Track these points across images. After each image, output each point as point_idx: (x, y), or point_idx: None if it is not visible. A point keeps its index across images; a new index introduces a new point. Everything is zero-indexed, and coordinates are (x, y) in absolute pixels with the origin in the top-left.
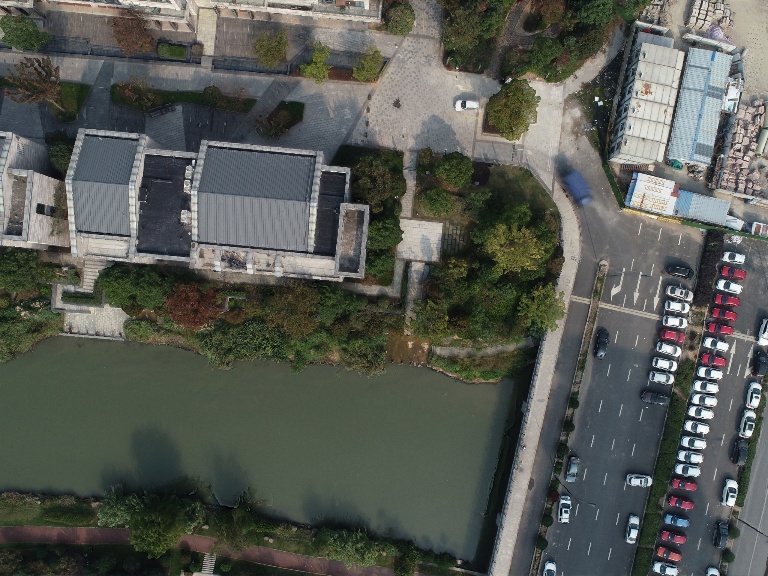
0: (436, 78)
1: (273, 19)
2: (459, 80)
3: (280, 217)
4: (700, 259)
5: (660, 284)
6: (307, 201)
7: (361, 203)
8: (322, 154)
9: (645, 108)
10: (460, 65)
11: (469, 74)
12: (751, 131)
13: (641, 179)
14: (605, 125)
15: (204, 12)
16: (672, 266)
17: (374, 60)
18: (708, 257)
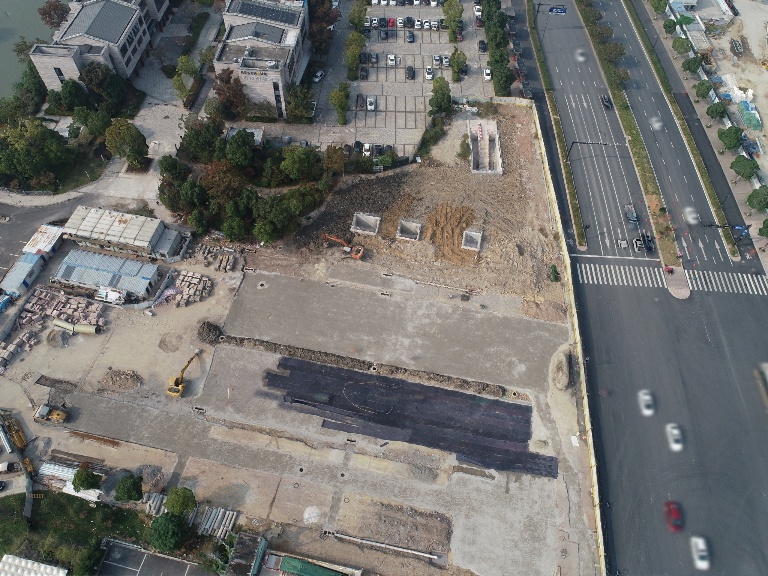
0: None
1: None
2: None
3: None
4: None
5: None
6: None
7: None
8: (116, 46)
9: (108, 220)
10: None
11: None
12: None
13: (59, 230)
14: None
15: None
16: None
17: (182, 86)
18: None
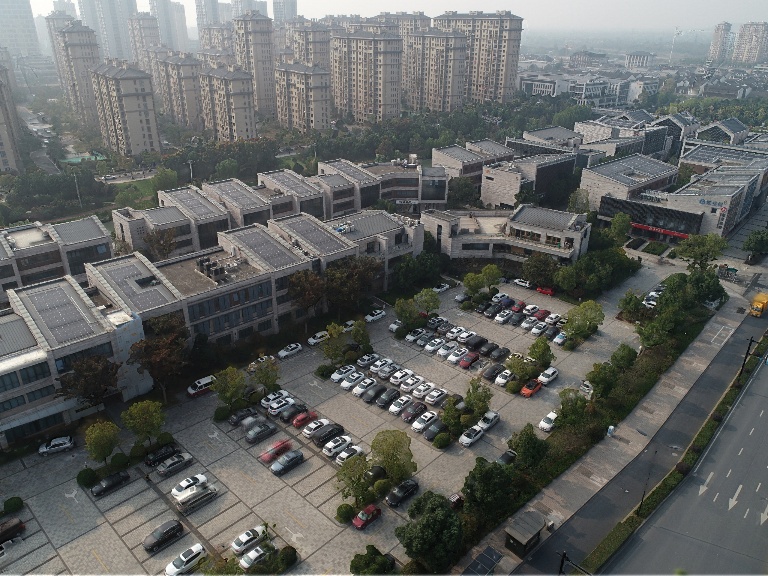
0: None
1: None
2: None
3: None
4: None
5: None
6: None
7: None
8: None
9: None
10: None
11: None
12: None
13: None
14: None
15: None
16: None
17: None
18: None
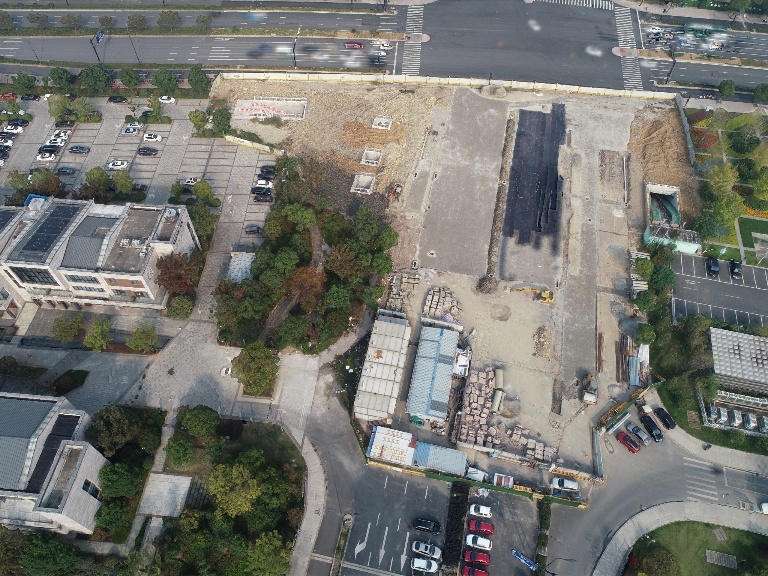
0: (209, 352)
1: (83, 309)
2: (229, 353)
3: (1, 454)
4: (447, 513)
5: (407, 540)
6: (31, 438)
7: (98, 449)
8: (64, 399)
9: (377, 369)
10: (231, 341)
11: (238, 348)
12: (487, 393)
13: (380, 431)
14: (354, 388)
15: (29, 305)
16: (416, 519)
17: (146, 332)
18: (453, 509)
